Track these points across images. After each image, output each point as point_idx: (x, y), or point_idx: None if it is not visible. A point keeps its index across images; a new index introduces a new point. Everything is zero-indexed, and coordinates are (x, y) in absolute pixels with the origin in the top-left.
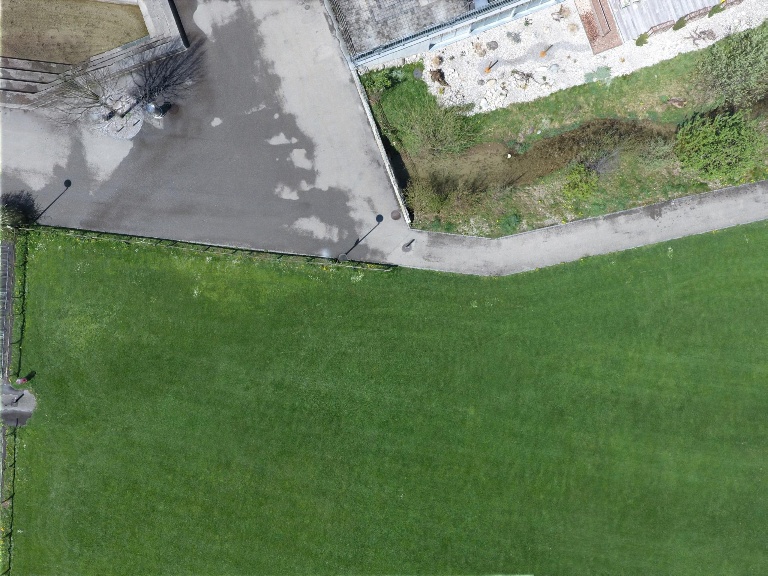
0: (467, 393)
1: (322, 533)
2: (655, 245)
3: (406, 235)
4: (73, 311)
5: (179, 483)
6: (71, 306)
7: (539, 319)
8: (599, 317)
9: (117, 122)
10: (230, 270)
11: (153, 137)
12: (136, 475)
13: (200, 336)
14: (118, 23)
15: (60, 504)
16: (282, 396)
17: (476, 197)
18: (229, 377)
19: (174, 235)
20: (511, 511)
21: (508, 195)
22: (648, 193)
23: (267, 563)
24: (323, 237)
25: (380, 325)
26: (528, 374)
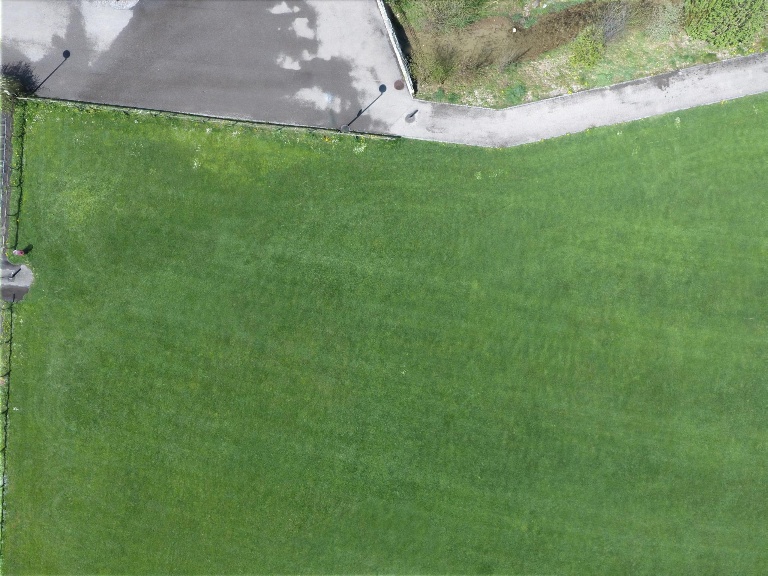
0: (470, 266)
1: (322, 411)
2: (662, 116)
3: (409, 105)
4: (71, 184)
5: (178, 359)
6: (69, 178)
7: (544, 191)
8: (605, 189)
9: None
10: (231, 141)
11: (153, 6)
12: (134, 351)
13: (200, 209)
14: None
15: (57, 381)
16: (283, 270)
17: (480, 71)
18: (229, 251)
19: (174, 107)
20: (514, 387)
21: (513, 69)
22: (655, 63)
23: (267, 441)
24: (325, 108)
25: (382, 197)
26: (533, 247)
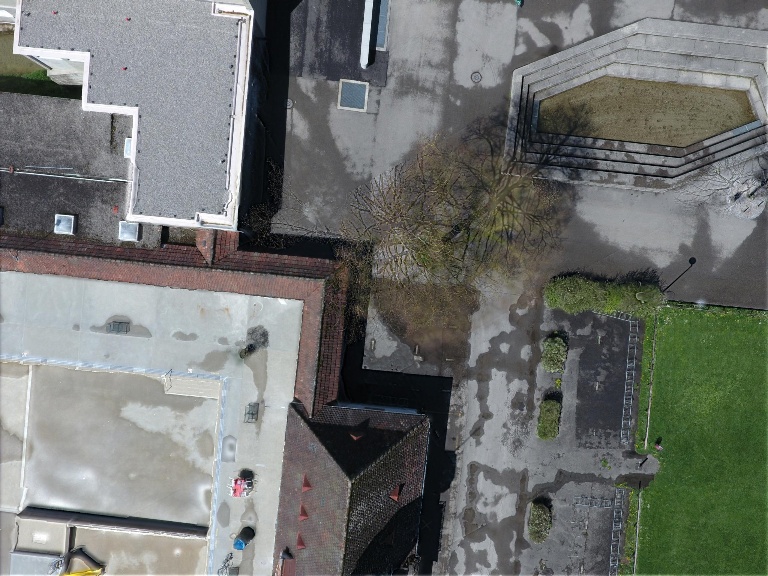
0: None
1: None
2: None
3: None
4: (698, 380)
5: None
6: (696, 376)
7: None
8: None
9: (742, 203)
10: None
11: None
12: (754, 531)
13: None
14: (721, 107)
15: (682, 560)
16: None
17: None
18: None
19: None
20: None
21: None
22: None
23: None
24: None
25: None
26: None
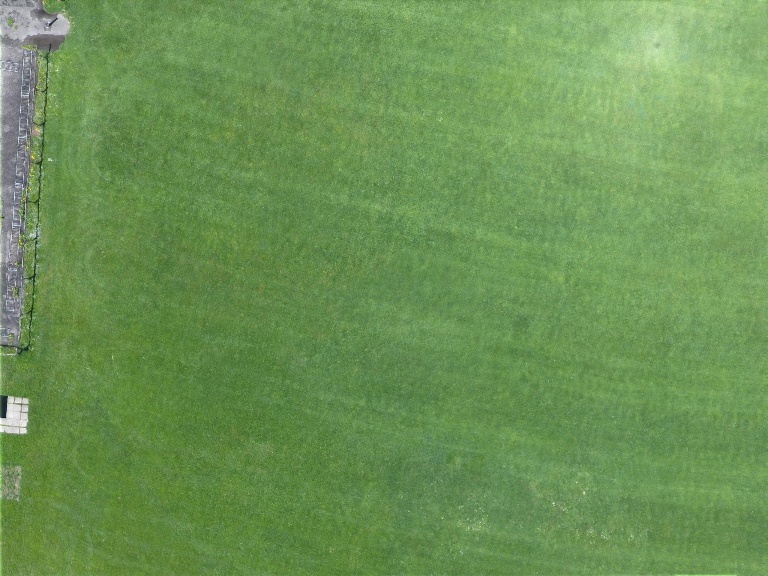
0: (509, 10)
1: (358, 160)
2: None
3: None
4: None
5: (213, 108)
6: None
7: None
8: None
9: None
10: None
11: None
12: (170, 100)
13: None
14: None
15: (92, 130)
16: (320, 16)
17: None
18: None
19: None
20: (553, 133)
21: None
22: None
23: (301, 191)
24: None
25: None
26: None
